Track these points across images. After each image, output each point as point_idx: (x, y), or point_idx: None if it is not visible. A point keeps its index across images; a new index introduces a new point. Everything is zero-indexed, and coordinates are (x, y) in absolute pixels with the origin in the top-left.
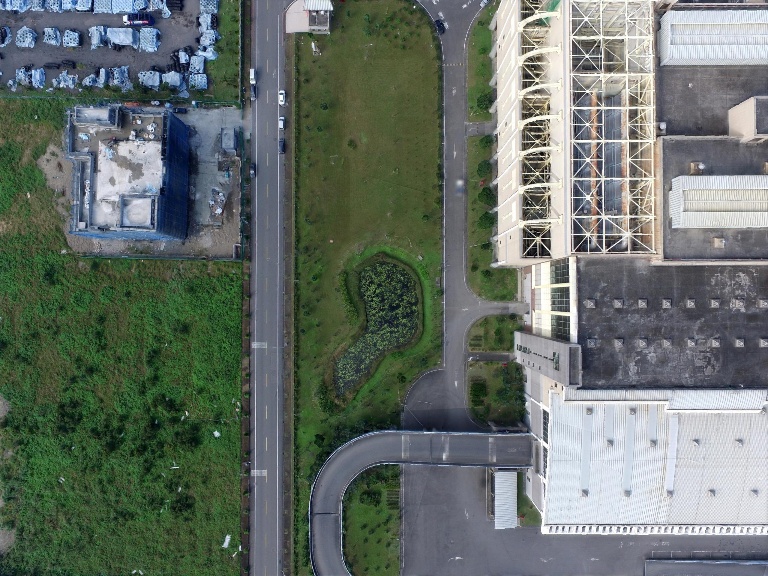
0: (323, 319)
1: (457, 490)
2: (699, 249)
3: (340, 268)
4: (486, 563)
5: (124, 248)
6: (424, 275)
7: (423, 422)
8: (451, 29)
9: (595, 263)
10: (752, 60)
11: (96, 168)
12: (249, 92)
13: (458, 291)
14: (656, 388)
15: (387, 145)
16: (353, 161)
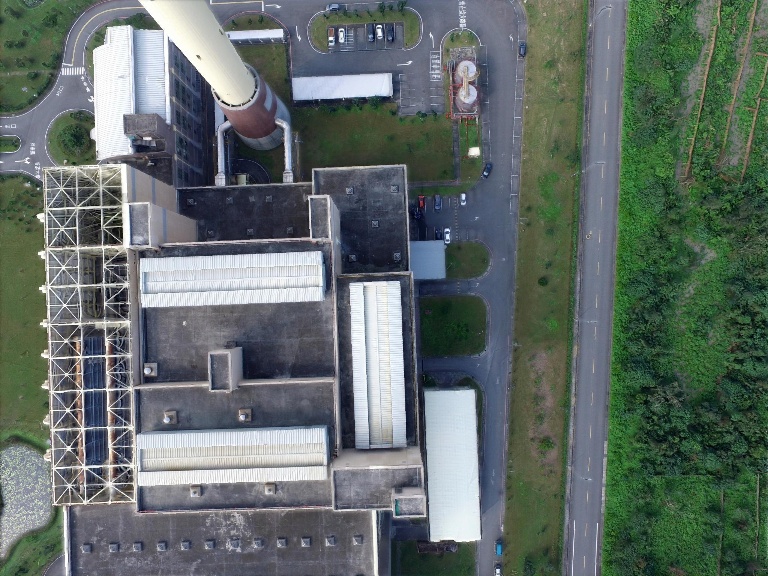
0: None
1: None
2: (179, 497)
3: None
4: None
5: None
6: None
7: None
8: None
9: (91, 507)
10: None
11: None
12: None
13: None
14: None
15: (17, 328)
16: None
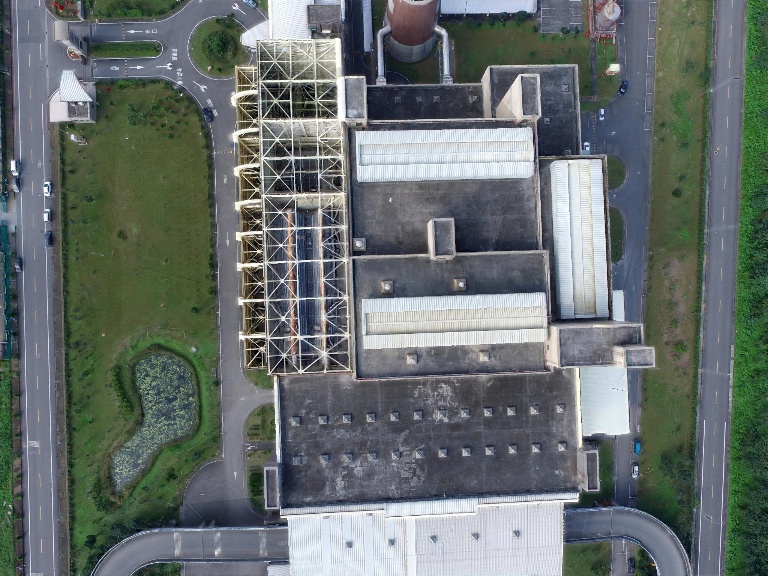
0: (97, 415)
1: None
2: (394, 366)
3: (113, 362)
4: None
5: None
6: (199, 366)
7: (203, 515)
8: (220, 116)
9: (299, 380)
10: (442, 178)
11: None
12: (13, 184)
13: (235, 381)
14: (362, 502)
15: (158, 235)
16: (123, 252)
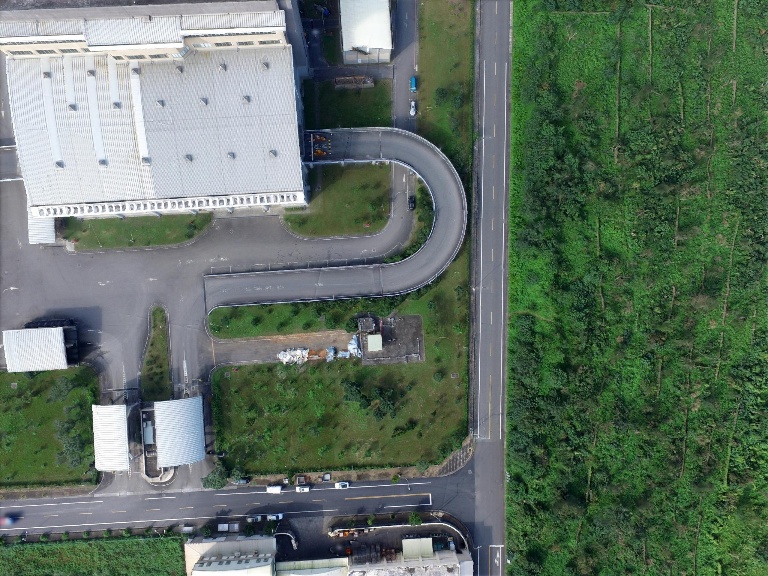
0: None
1: (9, 220)
2: None
3: None
4: (42, 291)
5: None
6: None
7: None
8: None
9: None
10: None
11: None
12: None
13: None
14: None
15: None
16: None
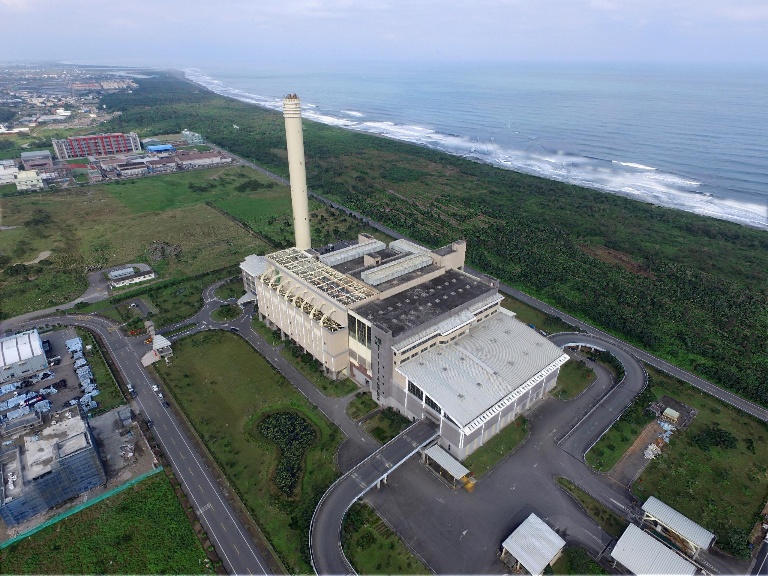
0: (247, 463)
1: (420, 491)
2: None
3: (242, 432)
4: (484, 520)
5: (44, 521)
6: (299, 406)
7: None
8: (241, 329)
9: (359, 309)
10: (358, 255)
11: (23, 453)
12: (130, 396)
13: (325, 402)
14: None
15: (235, 374)
16: (218, 388)
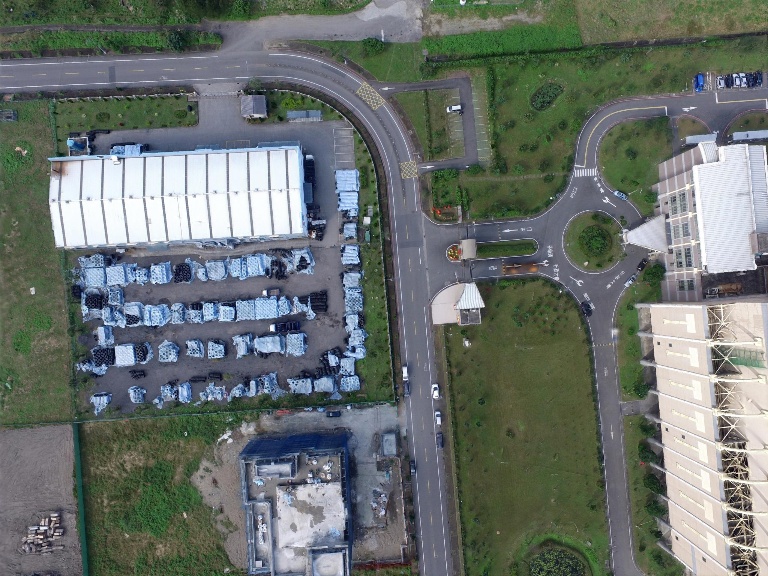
0: None
1: None
2: None
3: (509, 560)
4: None
5: None
6: (593, 559)
7: None
8: (597, 310)
9: None
10: None
11: (274, 513)
12: (402, 388)
13: (627, 571)
14: None
15: (545, 431)
16: (512, 450)
